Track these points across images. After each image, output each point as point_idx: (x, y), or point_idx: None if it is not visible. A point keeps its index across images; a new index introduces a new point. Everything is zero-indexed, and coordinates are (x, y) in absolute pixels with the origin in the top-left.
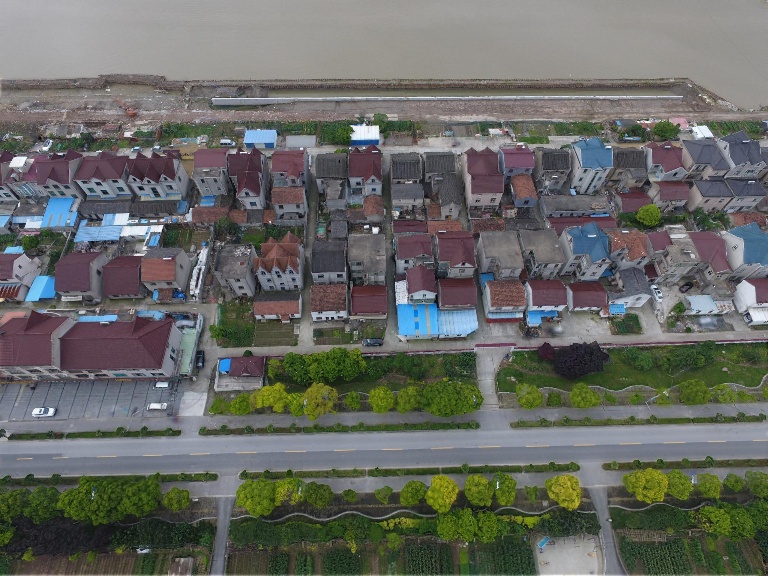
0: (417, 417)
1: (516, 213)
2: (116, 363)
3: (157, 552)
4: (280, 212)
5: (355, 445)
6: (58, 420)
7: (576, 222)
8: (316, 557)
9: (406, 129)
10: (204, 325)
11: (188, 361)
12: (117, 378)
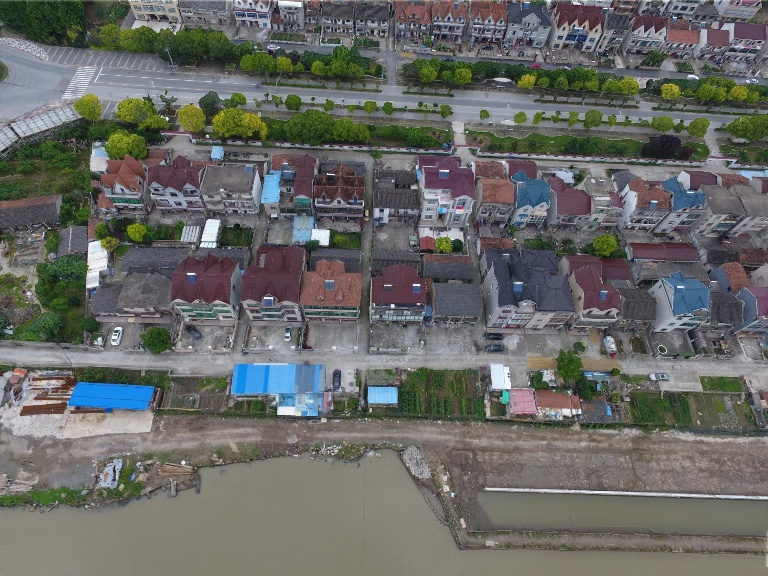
0: None
1: None
2: None
3: None
4: None
5: None
6: None
7: (673, 248)
8: None
9: None
10: None
11: None
12: None
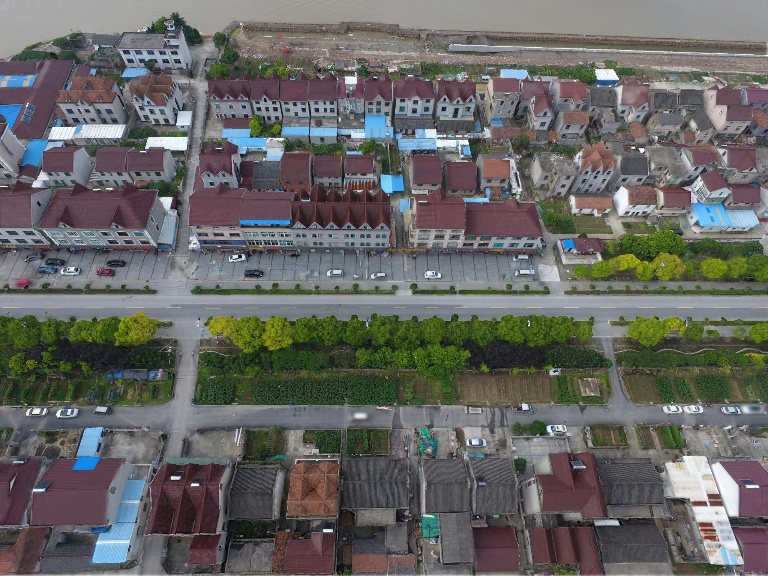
0: (731, 286)
1: (755, 140)
2: (508, 231)
3: (566, 374)
4: (563, 132)
5: (691, 304)
6: (445, 281)
7: None
8: (688, 381)
9: (632, 74)
10: None
11: None
12: (493, 248)
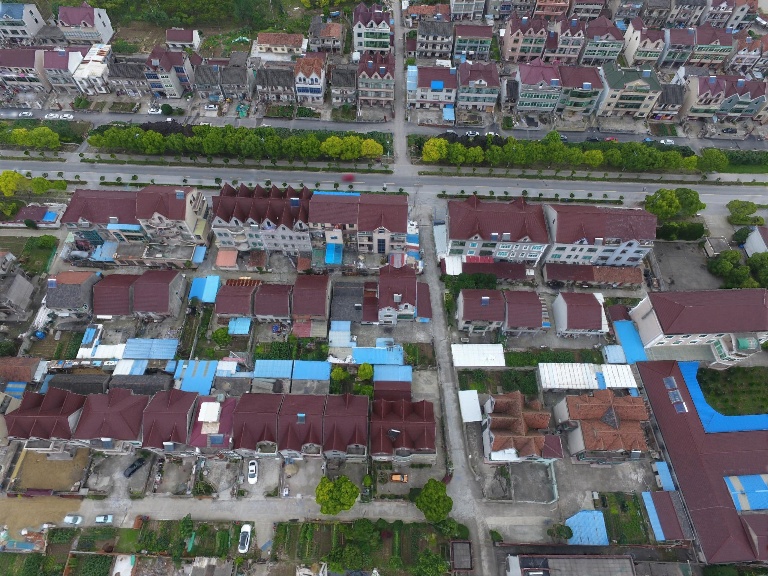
0: None
1: None
2: None
3: None
4: None
5: None
6: None
7: None
8: None
9: None
10: (66, 256)
11: None
12: None
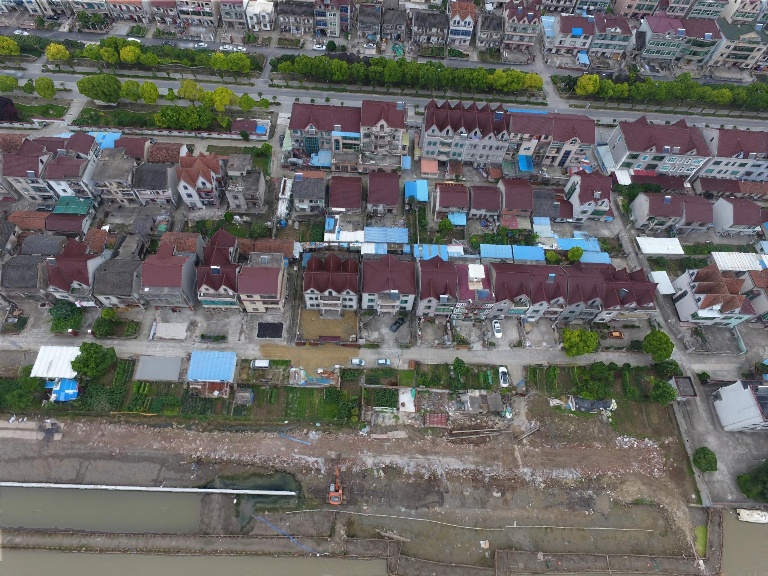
0: None
1: None
2: None
3: None
4: None
5: None
6: None
7: None
8: None
9: None
10: None
11: (287, 132)
12: None
